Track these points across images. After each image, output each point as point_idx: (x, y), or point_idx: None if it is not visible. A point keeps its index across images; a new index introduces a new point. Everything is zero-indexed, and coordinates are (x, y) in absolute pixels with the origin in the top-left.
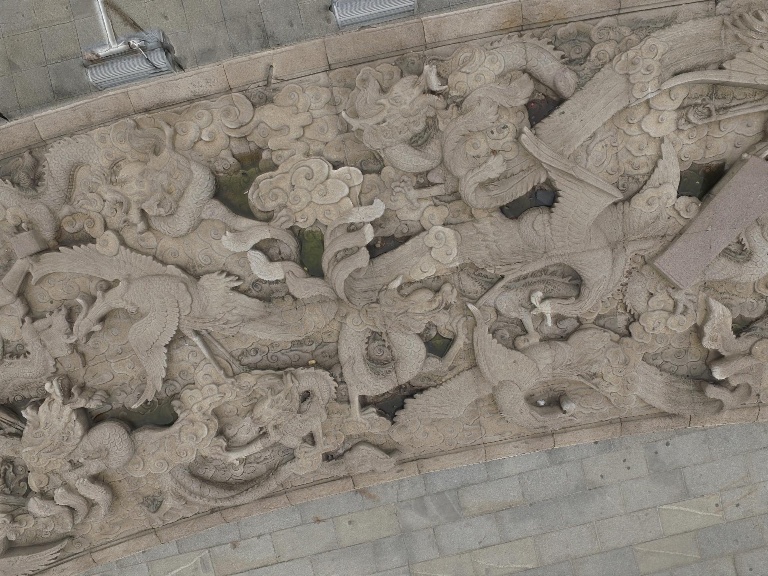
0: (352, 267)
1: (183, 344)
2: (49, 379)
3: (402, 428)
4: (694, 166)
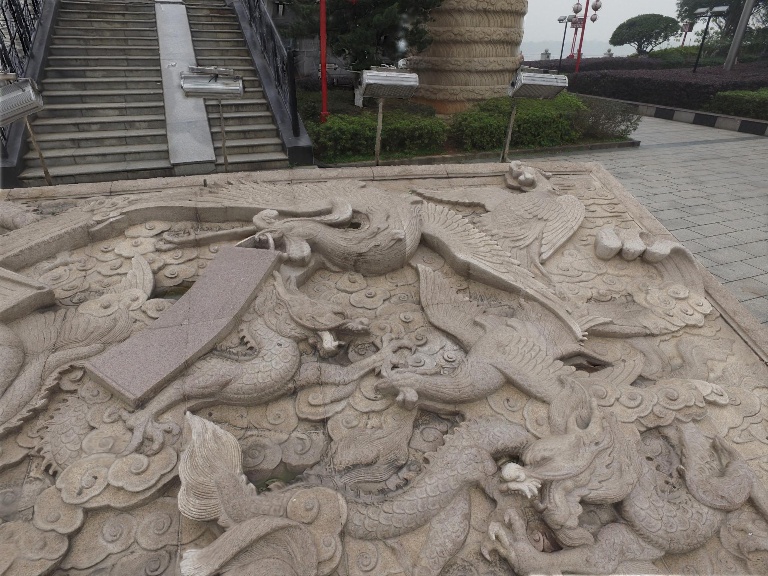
0: None
1: None
2: None
3: None
4: (186, 284)
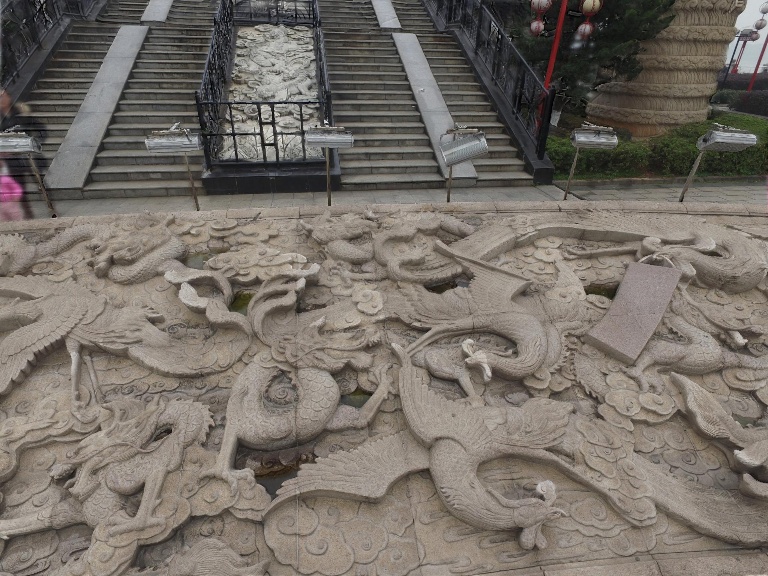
0: (277, 303)
1: (53, 372)
2: None
3: (287, 521)
4: (594, 285)
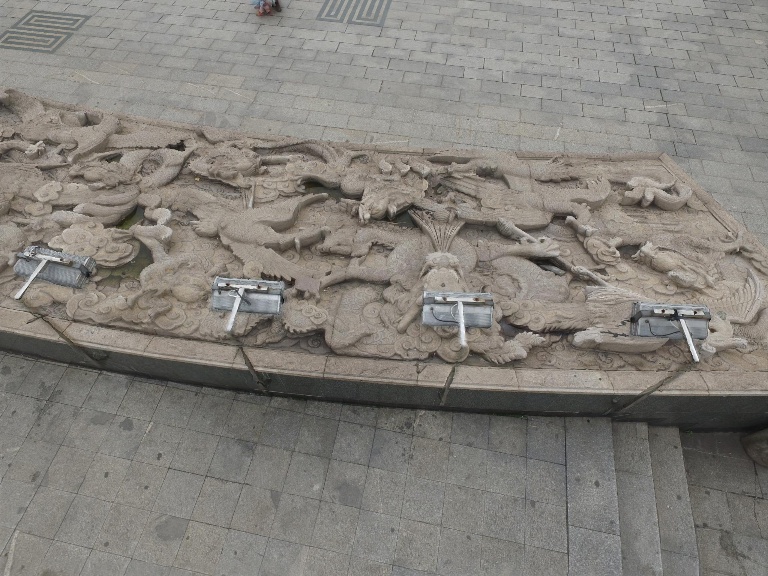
0: (110, 197)
1: None
2: (371, 227)
3: None
4: None
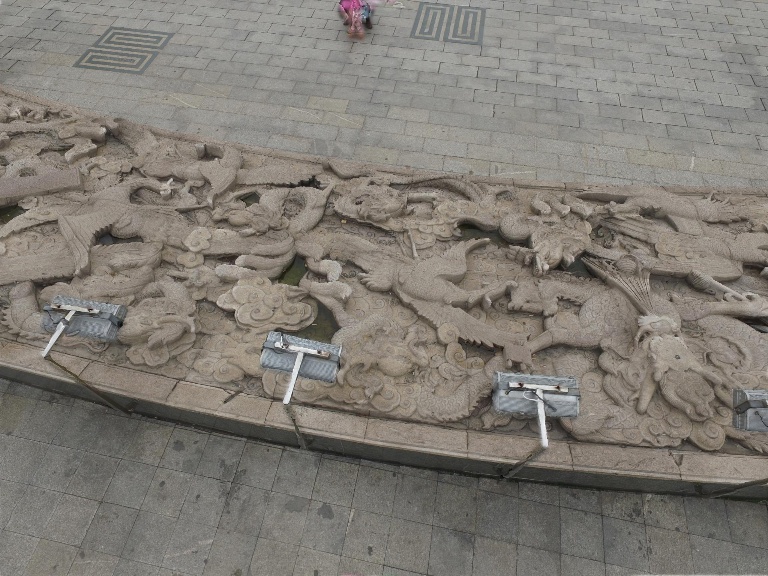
0: (269, 247)
1: None
2: (549, 278)
3: None
4: (0, 225)
